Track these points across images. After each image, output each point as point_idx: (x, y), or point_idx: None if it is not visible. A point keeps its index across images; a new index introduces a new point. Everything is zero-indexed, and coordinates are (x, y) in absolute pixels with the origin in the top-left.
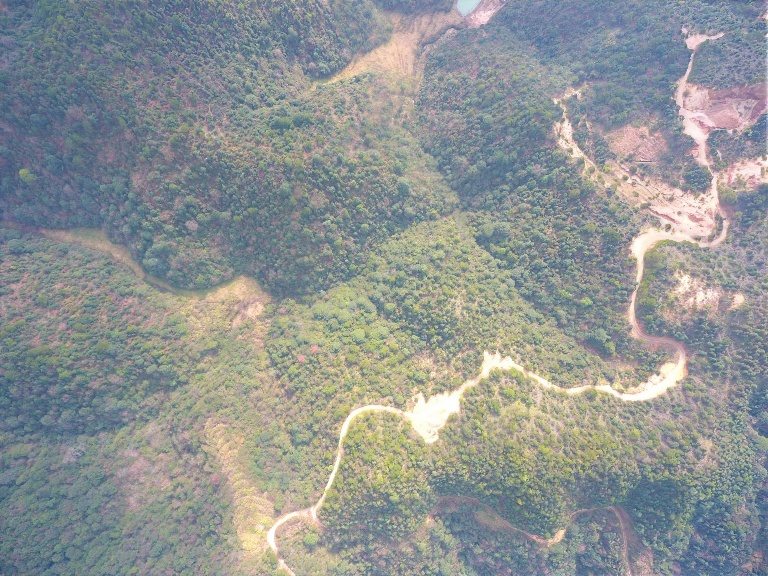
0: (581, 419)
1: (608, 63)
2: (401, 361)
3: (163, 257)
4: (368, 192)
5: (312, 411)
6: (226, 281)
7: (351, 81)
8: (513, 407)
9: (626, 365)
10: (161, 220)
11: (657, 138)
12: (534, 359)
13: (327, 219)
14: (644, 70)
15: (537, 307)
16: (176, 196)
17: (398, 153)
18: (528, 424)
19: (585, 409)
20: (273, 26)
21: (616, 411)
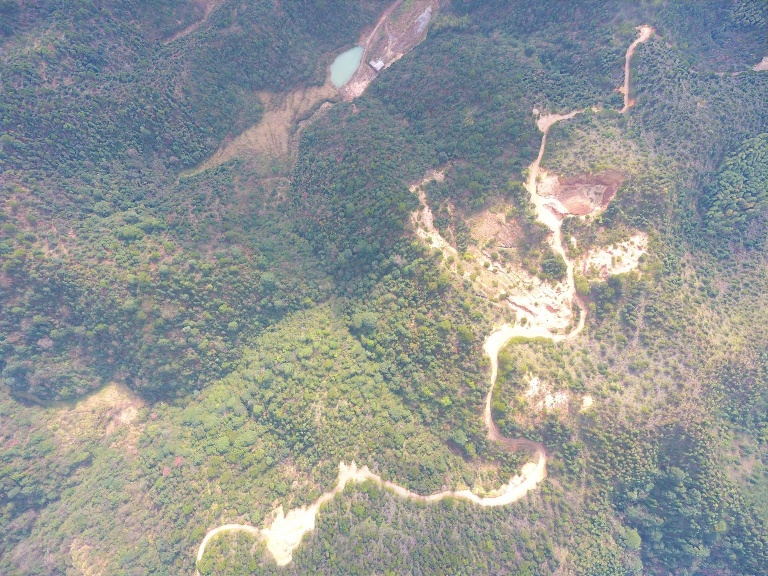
0: (433, 534)
1: (467, 144)
2: (265, 470)
3: (20, 376)
4: (229, 292)
5: (174, 529)
6: (96, 388)
7: (215, 172)
8: (363, 526)
9: (489, 465)
10: (10, 342)
11: (513, 225)
12: (392, 467)
13: (185, 325)
14: (500, 152)
15: (406, 402)
16: (21, 318)
17: (263, 246)
18: (376, 545)
19: (439, 522)
20: (123, 127)
21: (472, 520)
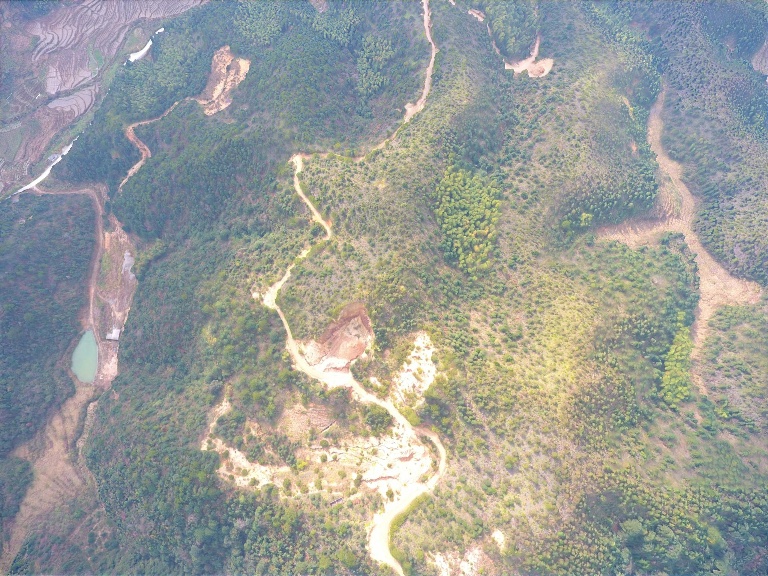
0: None
1: (225, 362)
2: None
3: None
4: None
5: None
6: None
7: None
8: None
9: None
10: None
11: (314, 407)
12: None
13: None
14: (255, 350)
15: None
16: None
17: None
18: None
19: None
20: None
21: None
